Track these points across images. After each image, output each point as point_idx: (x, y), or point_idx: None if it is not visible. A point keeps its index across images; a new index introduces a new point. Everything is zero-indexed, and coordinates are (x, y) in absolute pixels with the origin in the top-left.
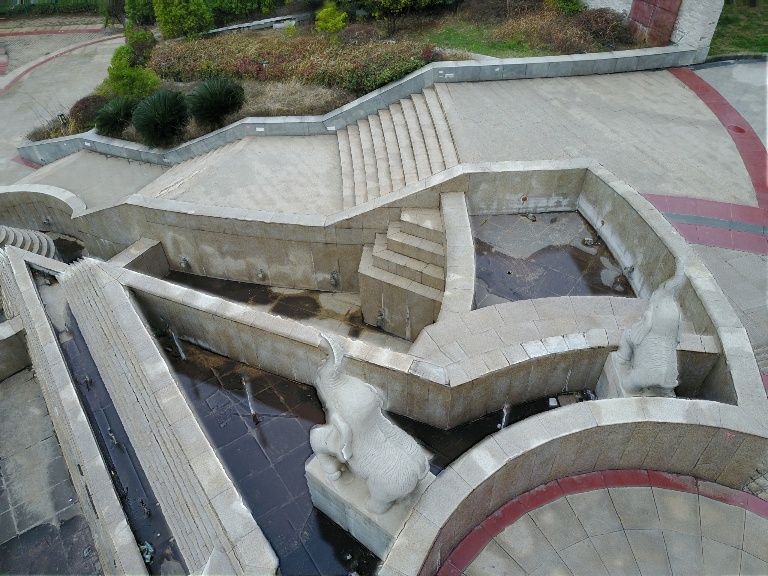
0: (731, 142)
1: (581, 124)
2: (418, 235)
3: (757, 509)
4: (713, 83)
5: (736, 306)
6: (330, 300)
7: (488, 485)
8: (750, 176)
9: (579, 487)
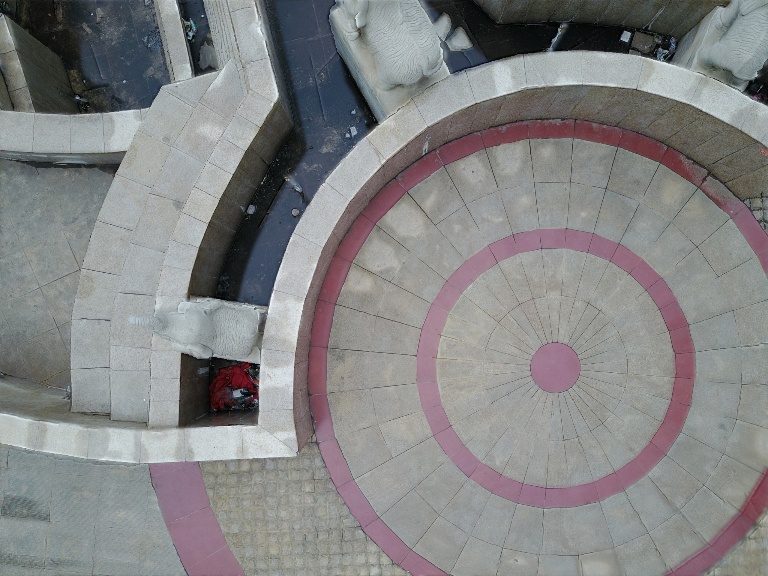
0: None
1: None
2: None
3: (741, 222)
4: None
5: None
6: None
7: (496, 103)
8: None
9: (592, 135)
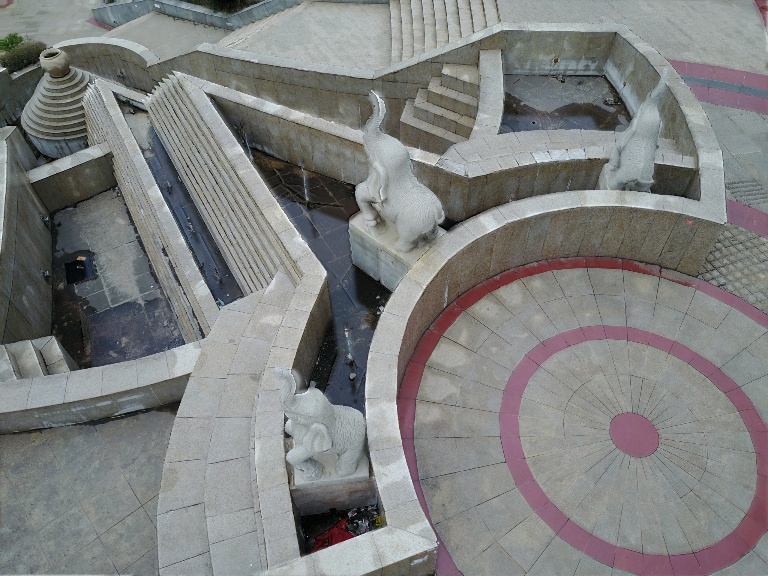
0: (761, 20)
1: None
2: (456, 89)
3: (705, 289)
4: None
5: (728, 151)
6: None
7: (489, 242)
8: None
9: (564, 265)
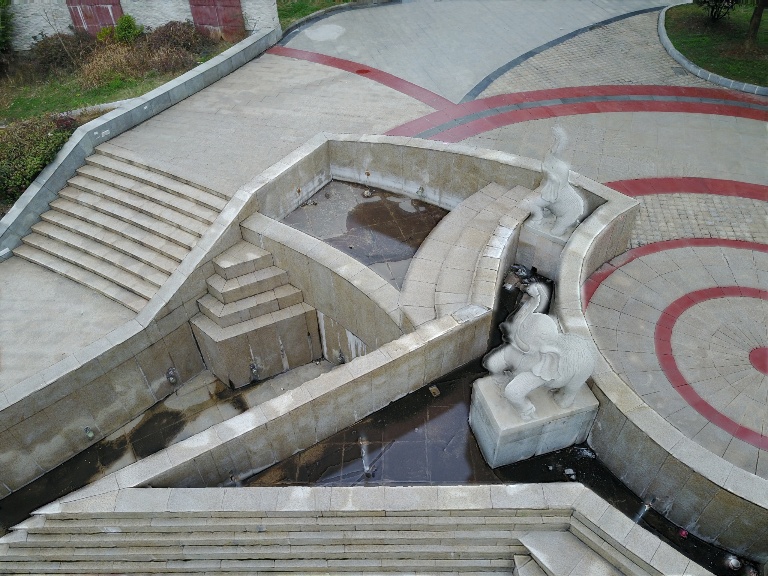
0: (371, 81)
1: (267, 117)
2: (246, 272)
3: (640, 254)
4: (307, 49)
5: None
6: (181, 400)
7: None
8: (409, 95)
9: None
